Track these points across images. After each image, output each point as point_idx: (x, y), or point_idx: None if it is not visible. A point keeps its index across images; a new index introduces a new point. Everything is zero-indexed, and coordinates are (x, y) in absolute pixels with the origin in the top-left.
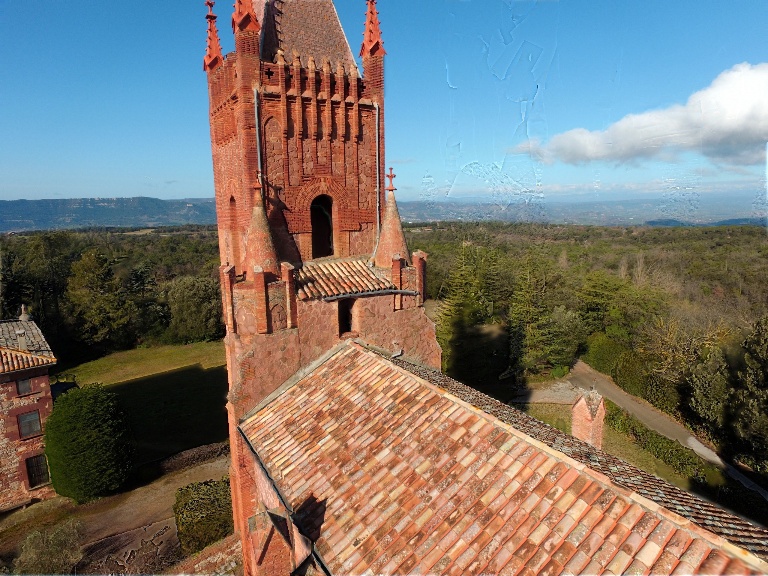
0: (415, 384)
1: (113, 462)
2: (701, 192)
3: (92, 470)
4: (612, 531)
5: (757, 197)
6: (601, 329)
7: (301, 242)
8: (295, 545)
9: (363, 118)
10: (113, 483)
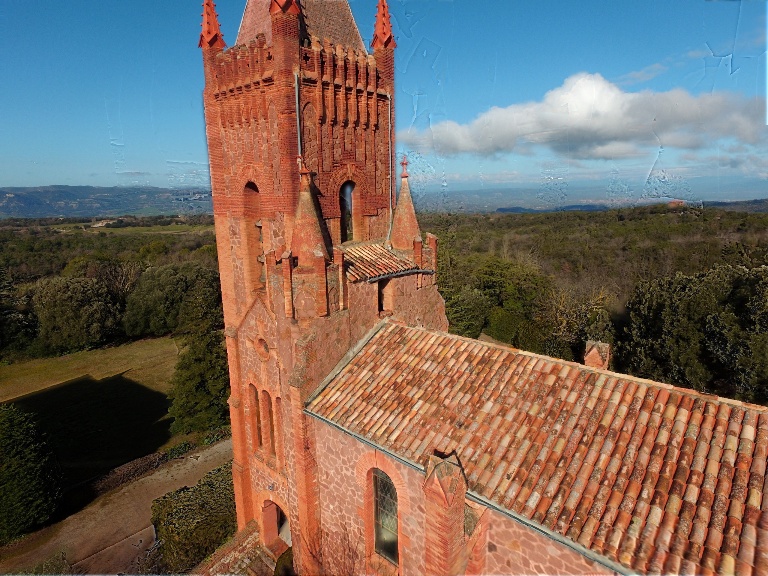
0: (483, 348)
1: (41, 491)
2: (569, 182)
3: (15, 504)
4: (716, 424)
5: (609, 186)
6: (498, 304)
7: (332, 227)
8: (398, 505)
9: (379, 107)
10: (42, 515)
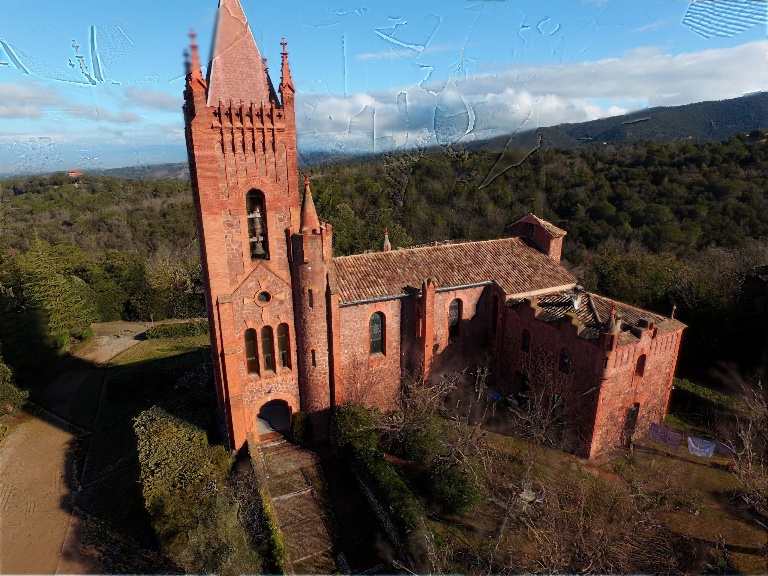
0: (373, 255)
1: None
2: (105, 162)
3: None
4: None
5: (135, 165)
6: None
7: None
8: (387, 321)
9: None
10: None
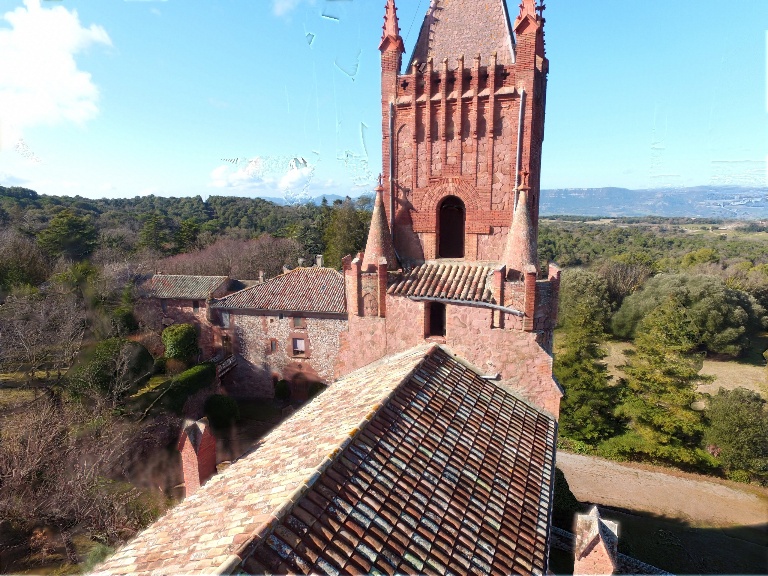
0: None
1: None
2: None
3: None
4: (199, 569)
5: None
6: None
7: (425, 241)
8: None
9: (503, 109)
10: None
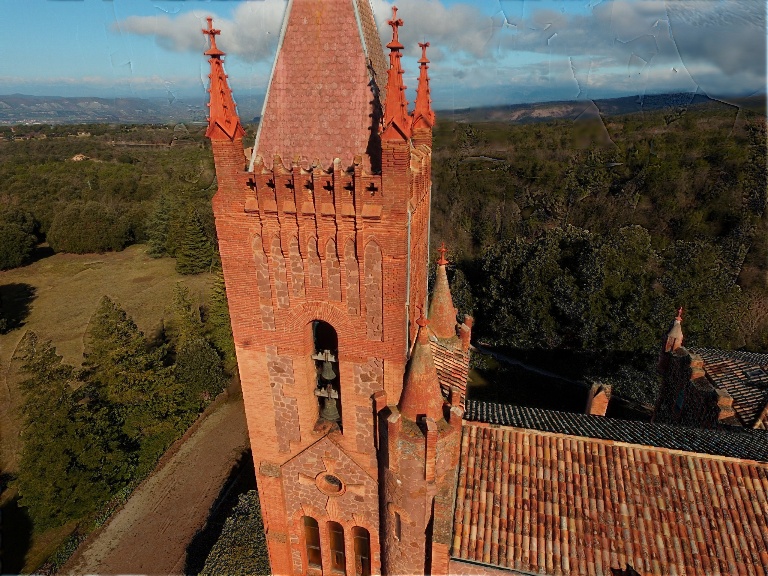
0: (580, 443)
1: None
2: None
3: None
4: None
5: None
6: None
7: None
8: None
9: None
10: None
